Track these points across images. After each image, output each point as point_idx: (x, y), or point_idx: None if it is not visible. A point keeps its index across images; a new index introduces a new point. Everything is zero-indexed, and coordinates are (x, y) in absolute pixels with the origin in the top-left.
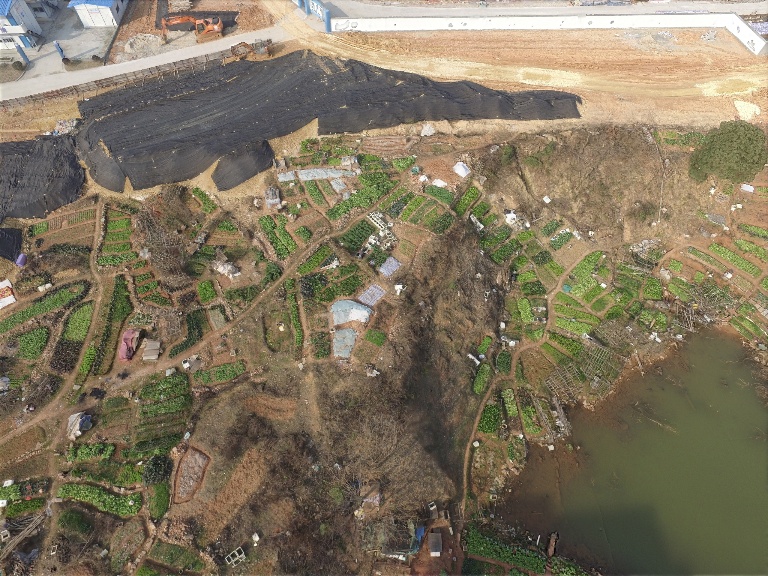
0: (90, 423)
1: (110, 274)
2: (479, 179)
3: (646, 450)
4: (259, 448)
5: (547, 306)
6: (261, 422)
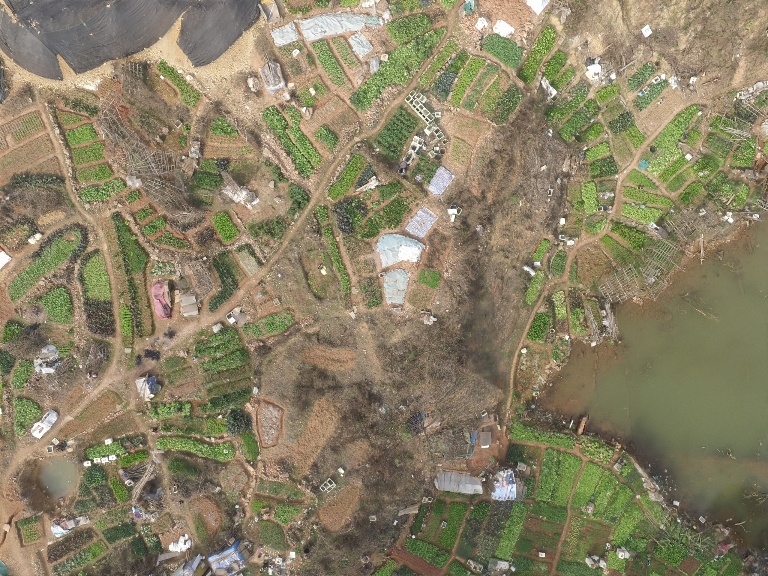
0: (158, 385)
1: (103, 213)
2: (560, 14)
3: (683, 339)
4: (327, 398)
5: (616, 189)
6: (324, 374)
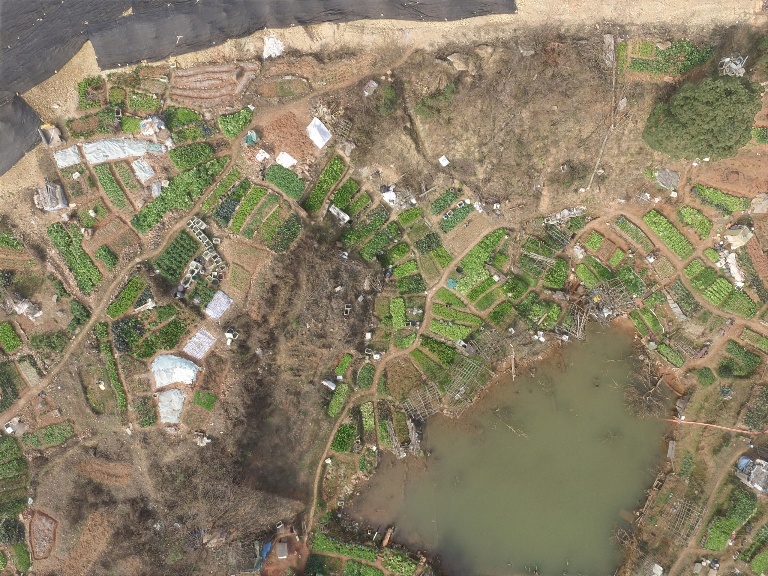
0: None
1: None
2: (344, 147)
3: (494, 454)
4: (101, 512)
5: (425, 305)
6: (98, 489)
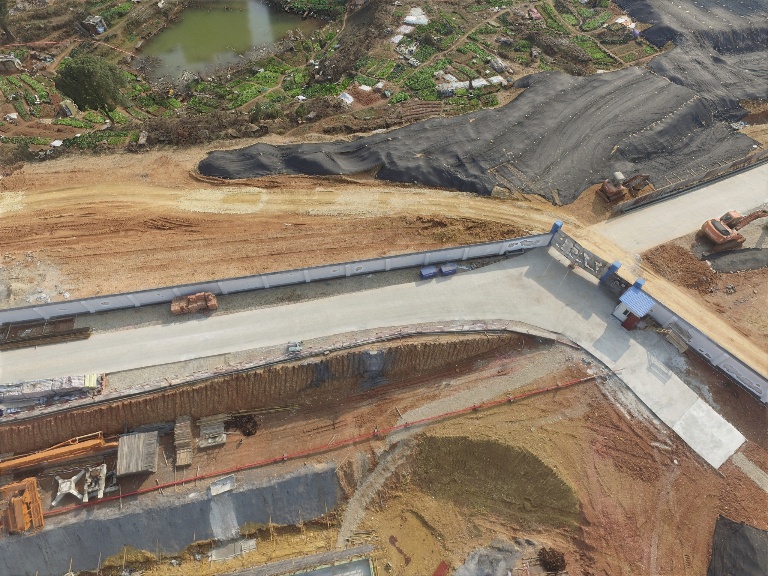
0: None
1: None
2: None
3: (245, 42)
4: None
5: None
6: None
